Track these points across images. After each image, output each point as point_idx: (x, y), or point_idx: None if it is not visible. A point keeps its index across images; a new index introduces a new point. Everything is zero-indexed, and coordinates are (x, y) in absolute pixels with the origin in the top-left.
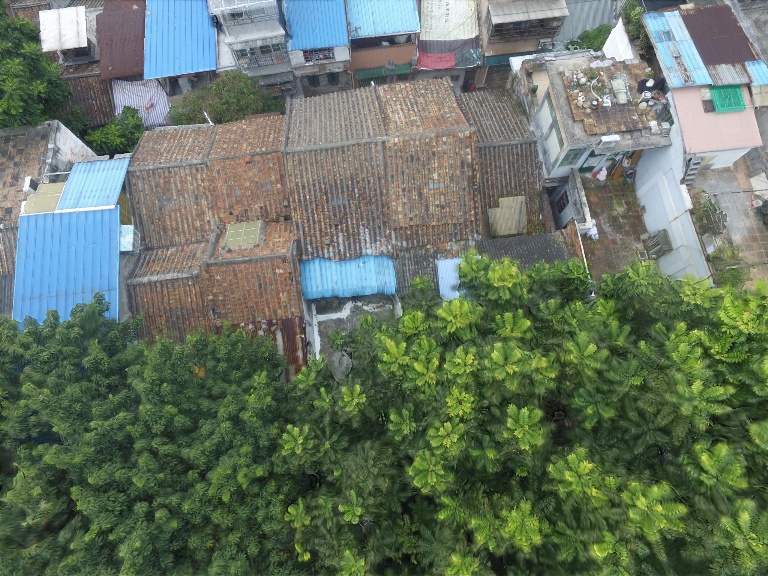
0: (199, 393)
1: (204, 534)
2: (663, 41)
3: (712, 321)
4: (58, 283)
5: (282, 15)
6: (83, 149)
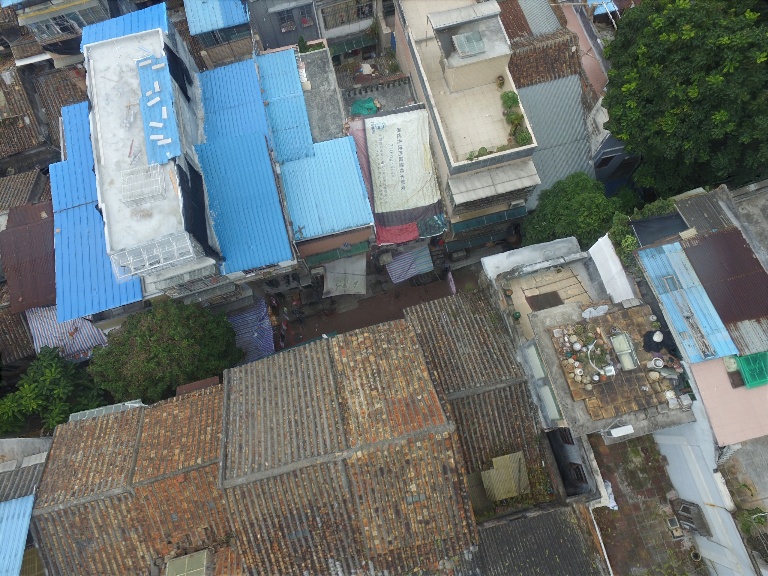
0: None
1: None
2: (668, 292)
3: None
4: None
5: (208, 248)
6: None
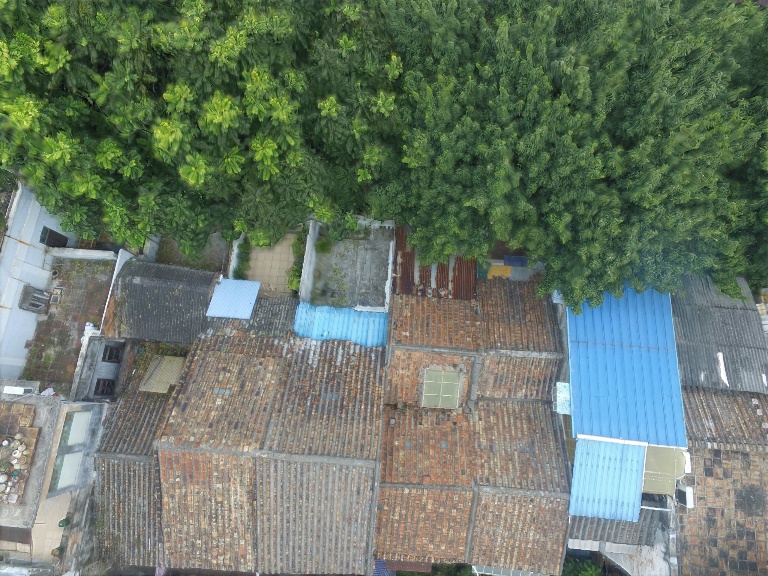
0: (473, 191)
1: (466, 78)
2: None
3: (25, 71)
4: (632, 360)
5: None
6: (643, 575)
